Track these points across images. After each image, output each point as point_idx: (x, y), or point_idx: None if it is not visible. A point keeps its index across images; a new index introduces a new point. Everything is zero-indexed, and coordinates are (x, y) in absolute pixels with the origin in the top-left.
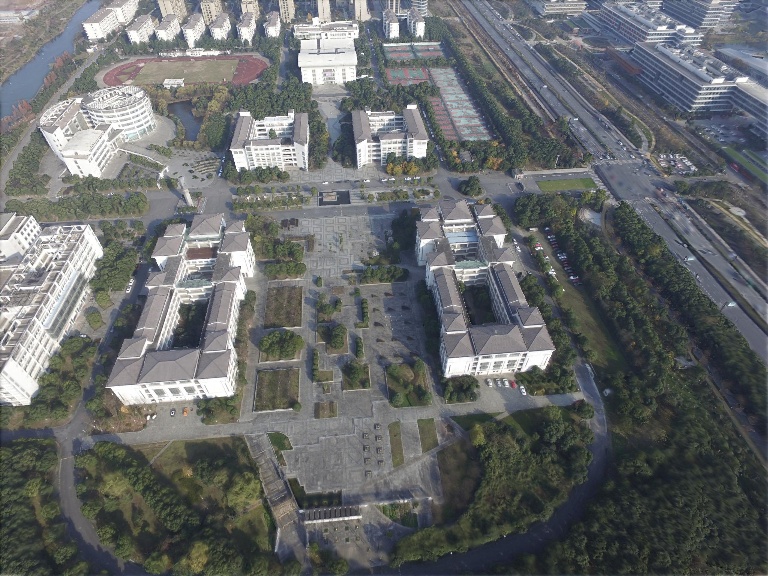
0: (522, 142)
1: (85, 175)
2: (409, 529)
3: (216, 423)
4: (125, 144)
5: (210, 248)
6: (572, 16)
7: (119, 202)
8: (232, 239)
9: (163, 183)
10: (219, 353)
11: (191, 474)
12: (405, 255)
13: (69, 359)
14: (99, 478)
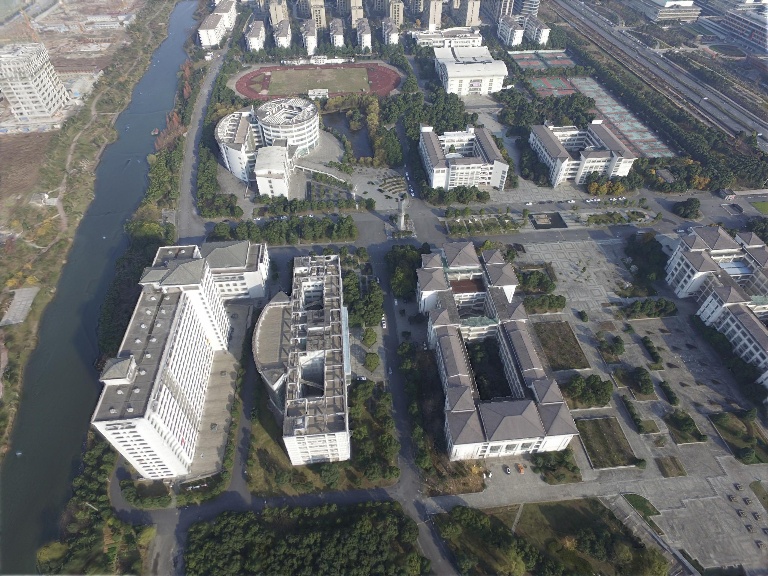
0: (719, 160)
1: (275, 195)
2: None
3: (560, 482)
4: (300, 160)
5: (470, 280)
6: (684, 22)
7: (328, 225)
8: (500, 271)
9: (362, 204)
10: (557, 405)
11: (575, 546)
12: (658, 286)
13: (361, 406)
14: (466, 549)
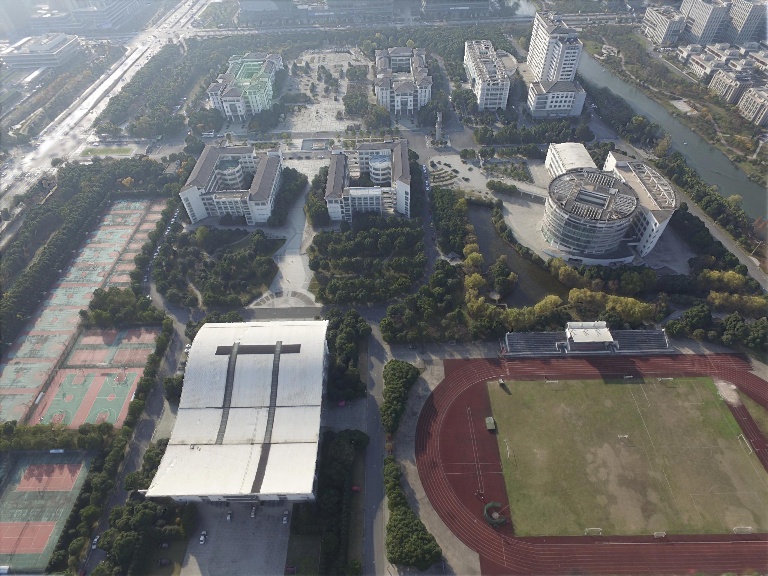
0: None
1: None
2: None
3: None
4: None
5: None
6: None
7: None
8: None
9: None
10: None
11: None
12: None
13: None
14: None
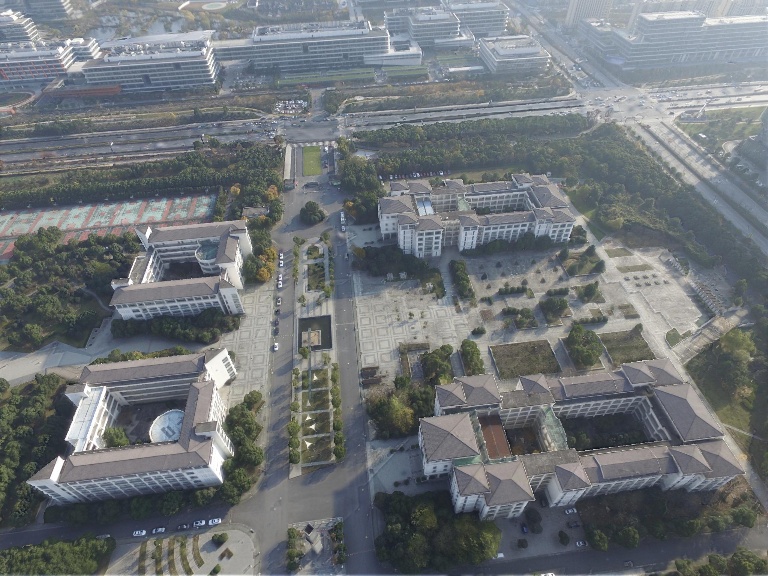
0: None
1: None
2: (689, 262)
3: None
4: None
5: None
6: None
7: None
8: (480, 390)
9: None
10: None
11: None
12: None
13: None
14: None
